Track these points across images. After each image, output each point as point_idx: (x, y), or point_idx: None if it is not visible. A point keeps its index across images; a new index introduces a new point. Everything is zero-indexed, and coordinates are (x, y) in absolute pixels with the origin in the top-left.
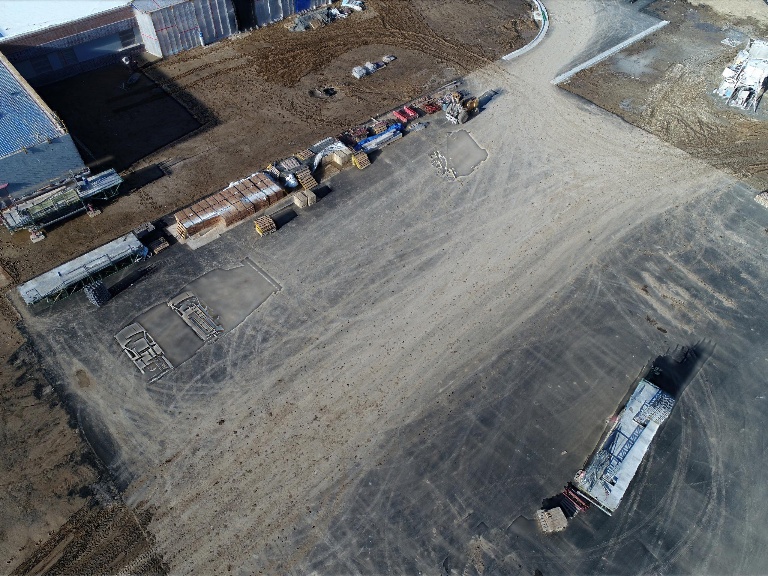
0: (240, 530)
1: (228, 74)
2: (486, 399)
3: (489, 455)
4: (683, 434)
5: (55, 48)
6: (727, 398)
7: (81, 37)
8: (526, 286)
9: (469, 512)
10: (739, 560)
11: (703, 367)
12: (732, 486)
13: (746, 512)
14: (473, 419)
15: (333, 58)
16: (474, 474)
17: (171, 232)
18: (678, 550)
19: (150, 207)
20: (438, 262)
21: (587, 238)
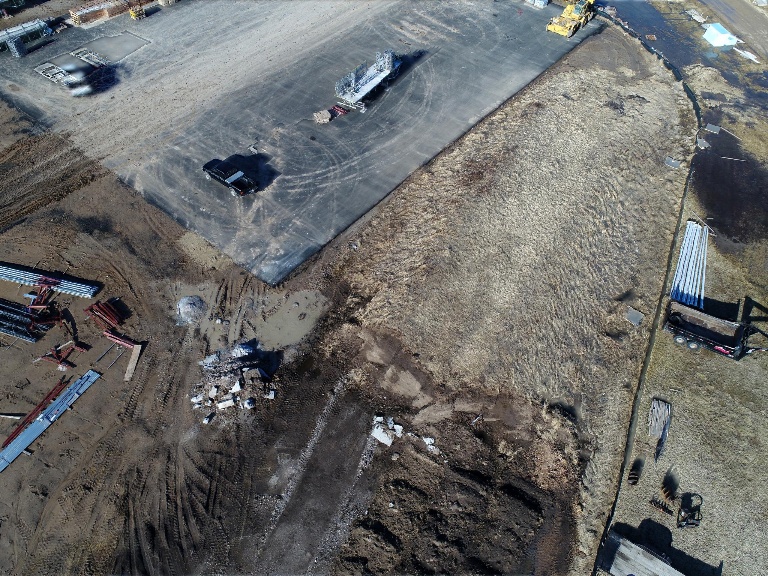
0: (128, 135)
1: None
2: (288, 78)
3: (288, 99)
4: (411, 84)
5: None
6: (442, 69)
7: None
8: (321, 31)
9: (273, 120)
10: (432, 125)
11: (431, 57)
12: (436, 100)
13: (441, 109)
14: (279, 86)
15: None
16: (277, 106)
17: (68, 22)
18: (397, 124)
19: (50, 12)
20: (262, 24)
21: (367, 8)
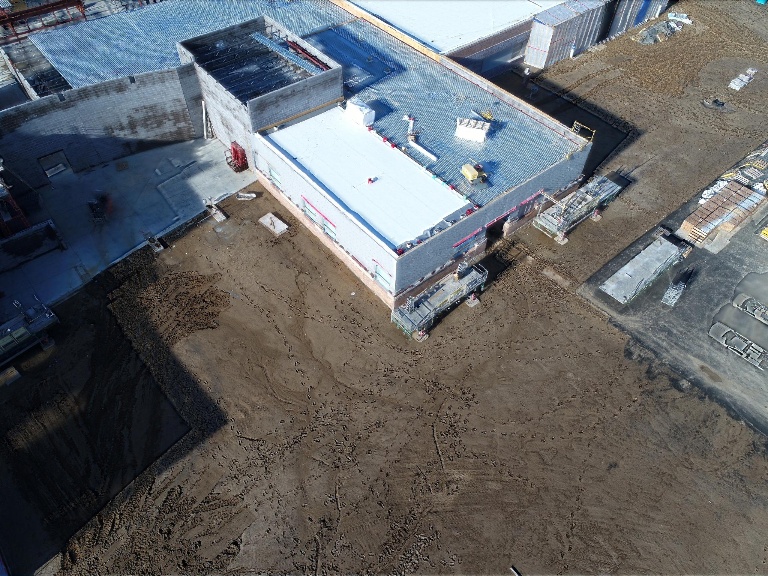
0: None
1: (614, 85)
2: None
3: None
4: None
5: (475, 60)
6: None
7: (493, 49)
8: None
9: None
10: None
11: None
12: None
13: None
14: None
15: (699, 70)
16: None
17: (682, 237)
18: None
19: (642, 212)
20: None
21: None
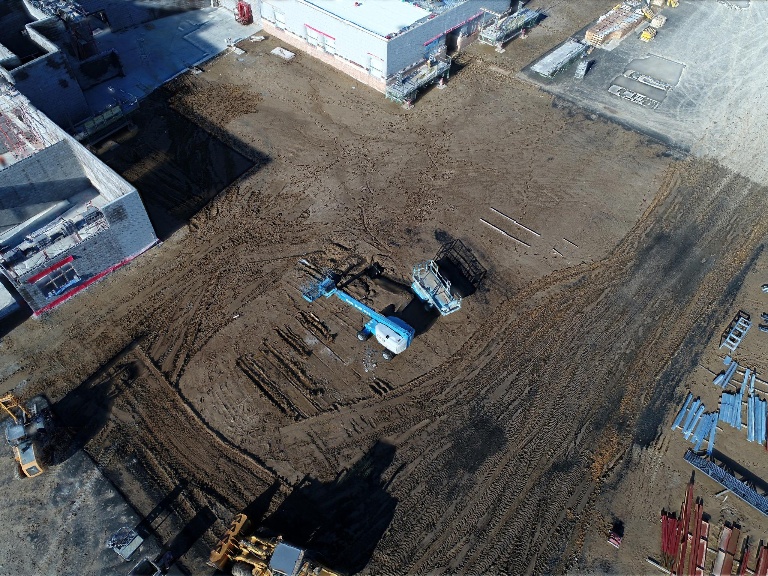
0: None
1: None
2: None
3: None
4: None
5: None
6: None
7: None
8: None
9: None
10: None
11: None
12: None
13: None
14: None
15: None
16: None
17: None
18: None
19: (557, 32)
20: None
21: None
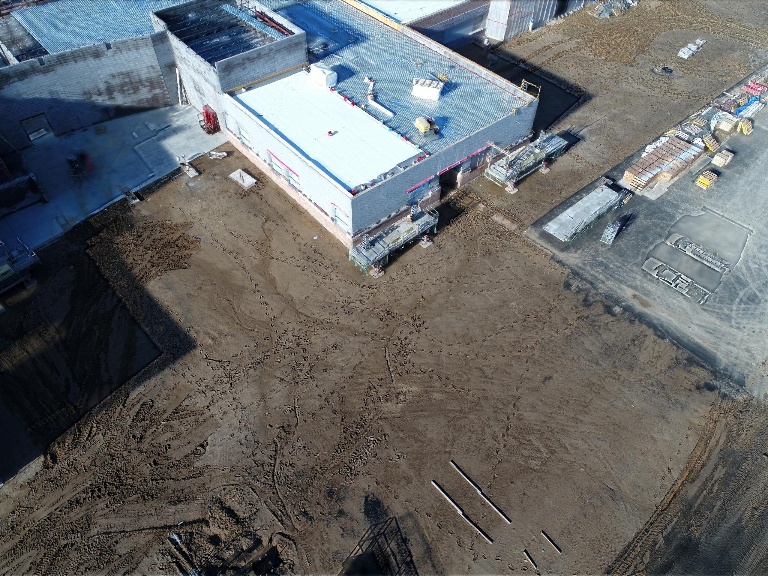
0: None
1: (569, 55)
2: None
3: None
4: None
5: (436, 30)
6: None
7: (453, 21)
8: None
9: None
10: None
11: None
12: None
13: None
14: None
15: (650, 41)
16: None
17: (623, 186)
18: None
19: (588, 166)
20: None
21: None
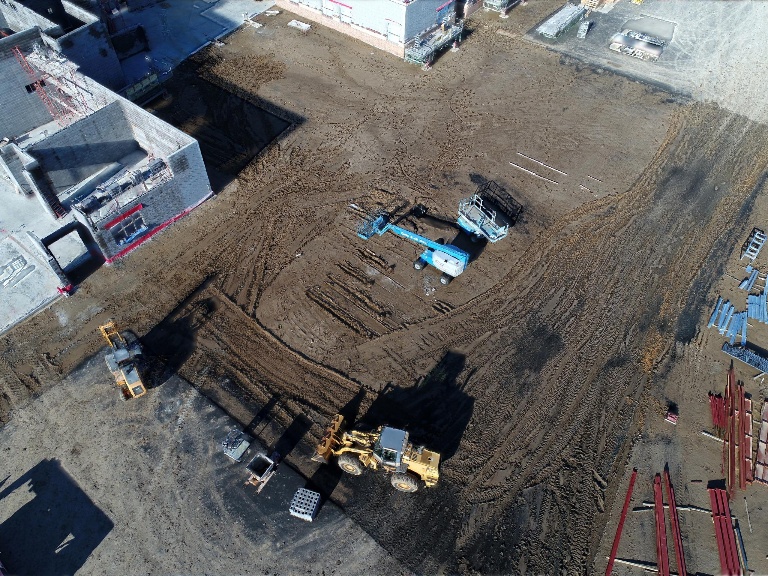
0: (766, 103)
1: None
2: None
3: None
4: None
5: None
6: None
7: None
8: None
9: None
10: None
11: None
12: None
13: None
14: None
15: None
16: None
17: None
18: None
19: None
20: (752, 7)
21: None
